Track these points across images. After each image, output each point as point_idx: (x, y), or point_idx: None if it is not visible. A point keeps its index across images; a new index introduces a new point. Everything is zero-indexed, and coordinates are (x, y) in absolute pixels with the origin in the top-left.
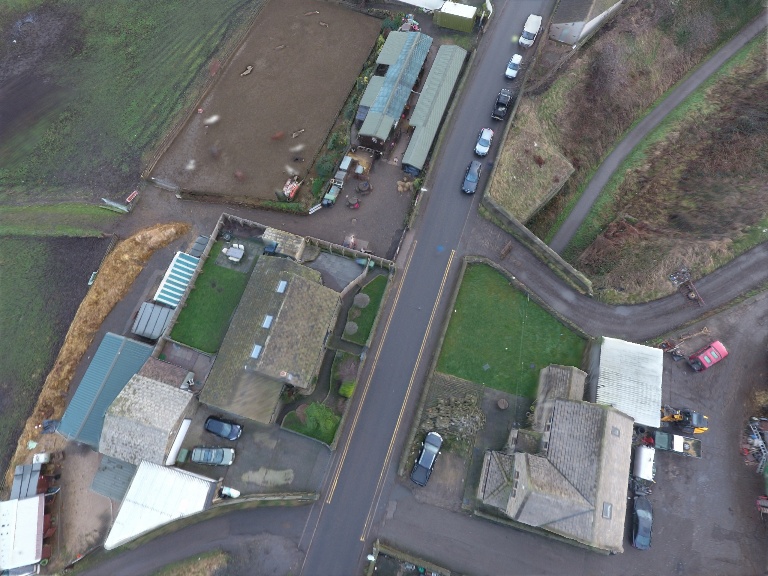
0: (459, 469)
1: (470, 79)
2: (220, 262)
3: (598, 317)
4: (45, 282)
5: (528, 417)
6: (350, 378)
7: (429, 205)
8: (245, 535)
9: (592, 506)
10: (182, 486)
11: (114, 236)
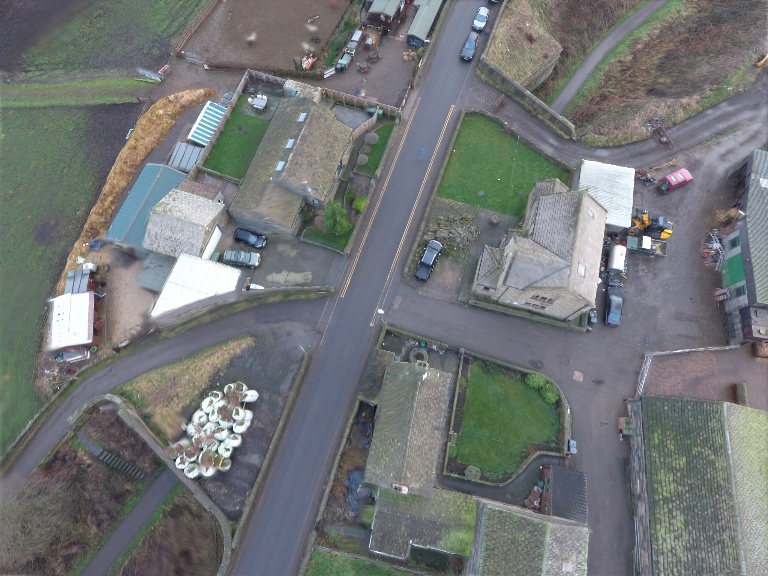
0: (456, 271)
1: None
2: (245, 111)
3: (580, 157)
4: (86, 140)
5: None
6: (362, 195)
7: (431, 69)
8: (270, 323)
9: (568, 262)
10: (217, 272)
11: (149, 98)
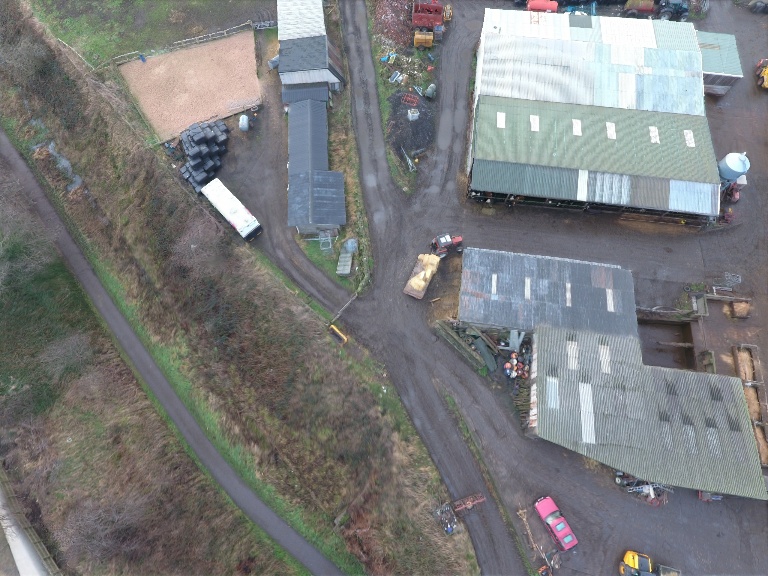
0: None
1: None
2: None
3: None
4: None
5: None
6: None
7: None
8: None
9: None
10: None
11: None
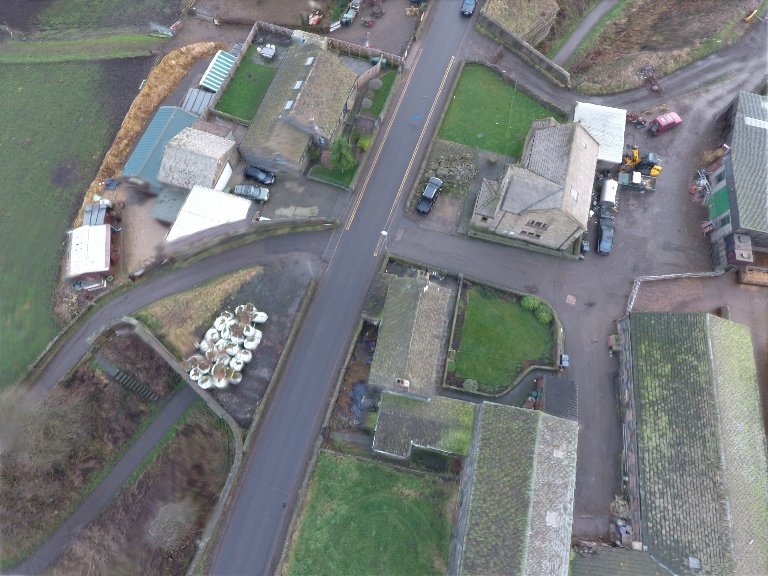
0: (456, 206)
1: None
2: (255, 60)
3: None
4: (101, 91)
5: None
6: (366, 135)
7: (433, 24)
8: (278, 253)
9: (562, 186)
10: (228, 202)
11: (161, 51)
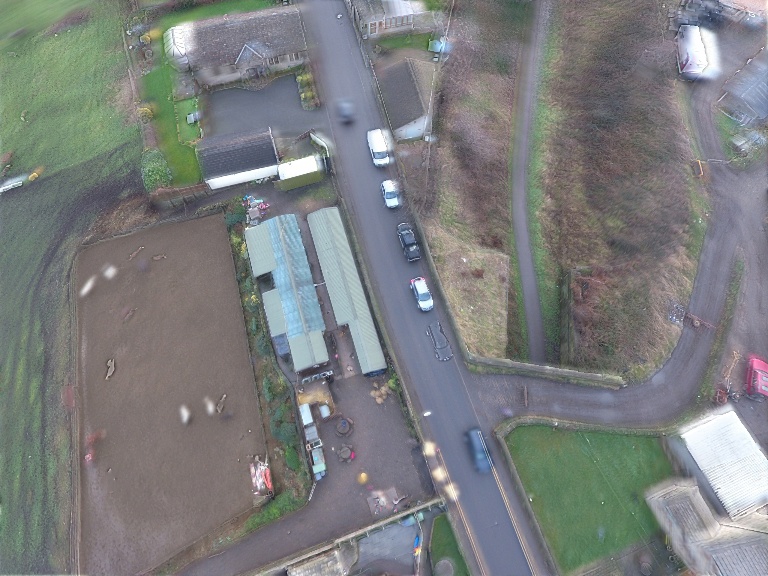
0: None
1: (358, 232)
2: None
3: (646, 403)
4: None
5: (674, 562)
6: None
7: (421, 400)
8: None
9: None
10: None
11: None
